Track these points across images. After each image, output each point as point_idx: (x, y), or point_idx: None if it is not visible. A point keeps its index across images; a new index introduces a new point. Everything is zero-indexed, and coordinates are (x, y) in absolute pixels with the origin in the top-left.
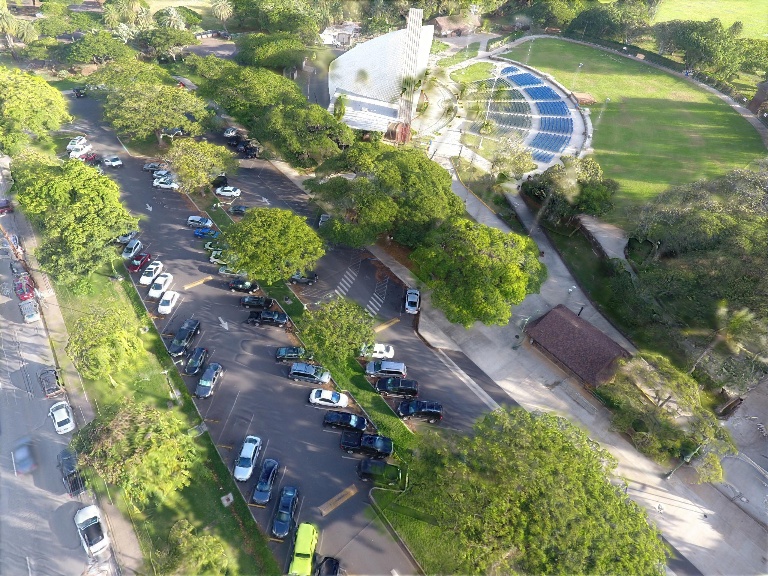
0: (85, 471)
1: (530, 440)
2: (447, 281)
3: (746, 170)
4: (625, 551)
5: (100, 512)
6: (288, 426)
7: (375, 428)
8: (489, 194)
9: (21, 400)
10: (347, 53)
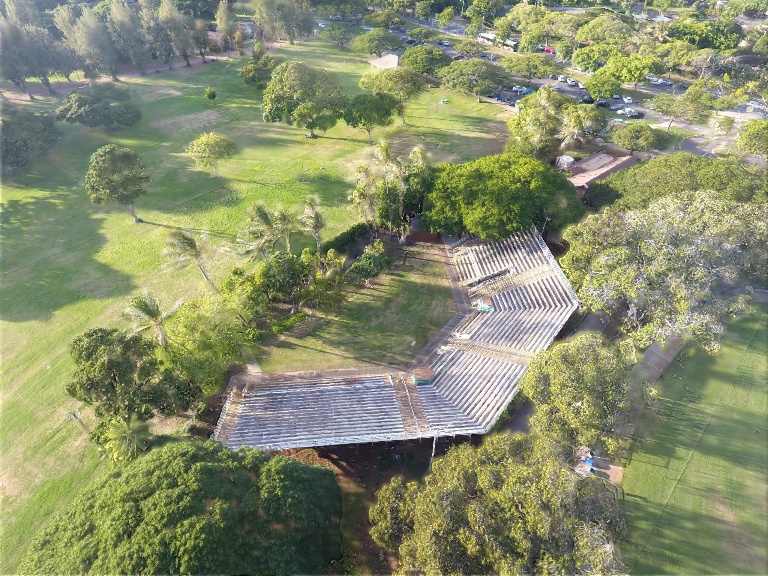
0: None
1: None
2: None
3: None
4: (760, 131)
5: None
6: None
7: None
8: None
9: None
10: None
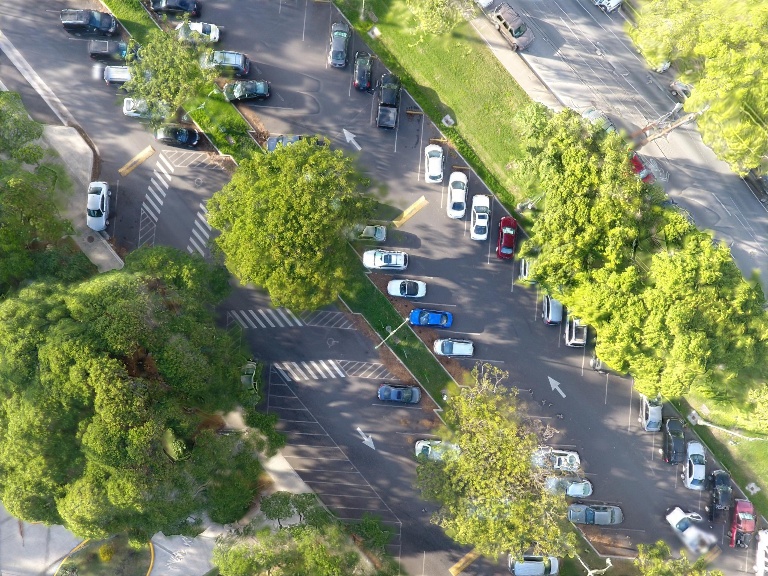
0: None
1: None
2: (7, 155)
3: None
4: None
5: None
6: (239, 2)
7: (143, 3)
8: None
9: (532, 7)
10: None
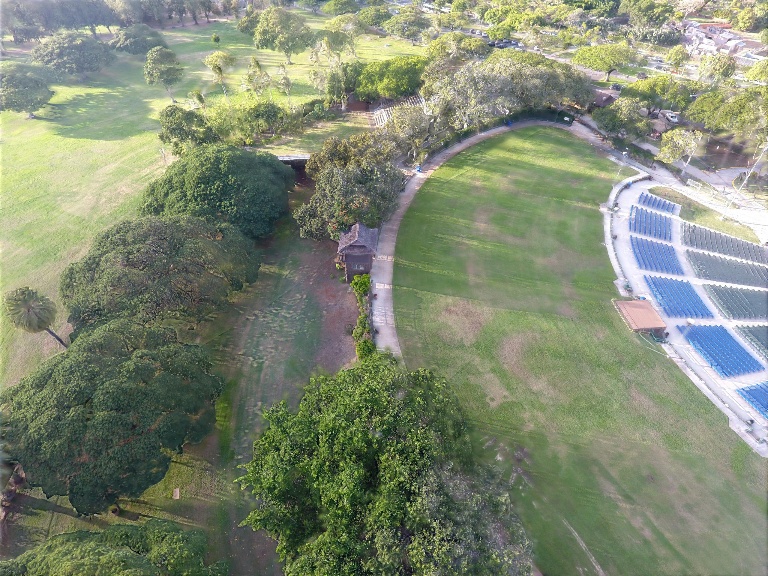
0: None
1: (615, 55)
2: None
3: (531, 84)
4: None
5: None
6: None
7: None
8: (674, 169)
9: None
10: None
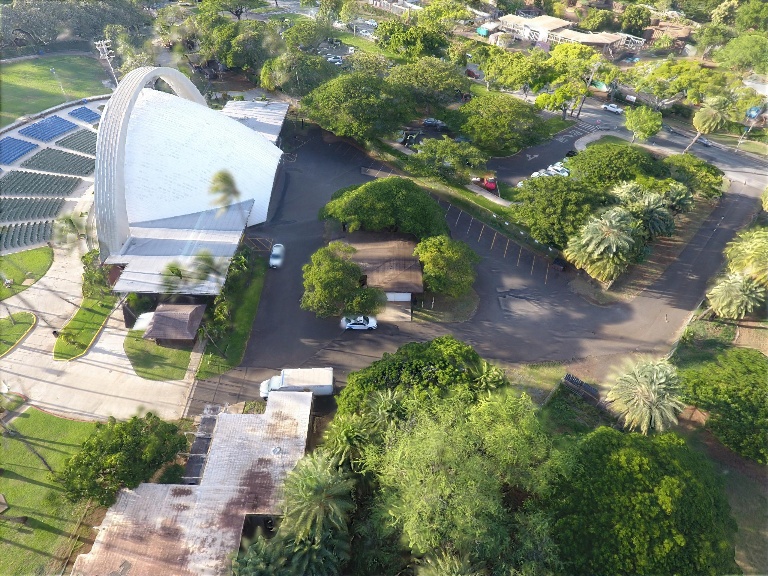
0: (349, 28)
1: None
2: None
3: (25, 12)
4: None
5: (340, 25)
6: None
7: None
8: None
9: None
10: (253, 137)
